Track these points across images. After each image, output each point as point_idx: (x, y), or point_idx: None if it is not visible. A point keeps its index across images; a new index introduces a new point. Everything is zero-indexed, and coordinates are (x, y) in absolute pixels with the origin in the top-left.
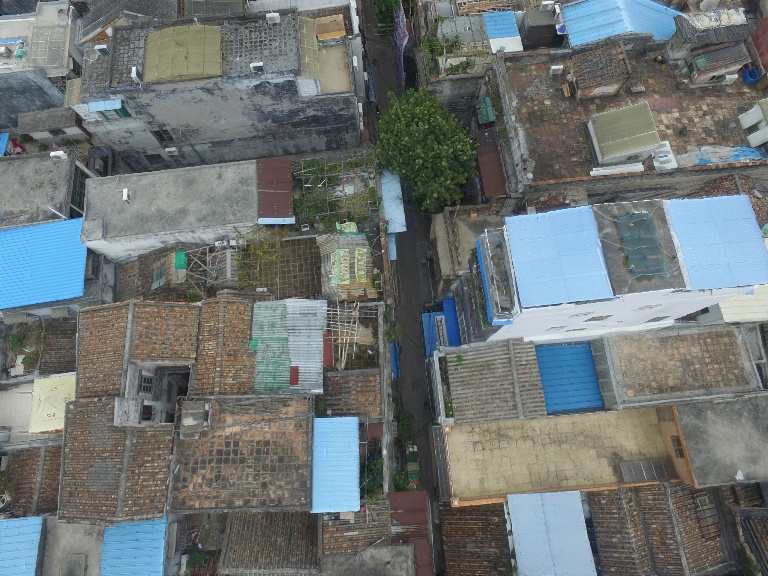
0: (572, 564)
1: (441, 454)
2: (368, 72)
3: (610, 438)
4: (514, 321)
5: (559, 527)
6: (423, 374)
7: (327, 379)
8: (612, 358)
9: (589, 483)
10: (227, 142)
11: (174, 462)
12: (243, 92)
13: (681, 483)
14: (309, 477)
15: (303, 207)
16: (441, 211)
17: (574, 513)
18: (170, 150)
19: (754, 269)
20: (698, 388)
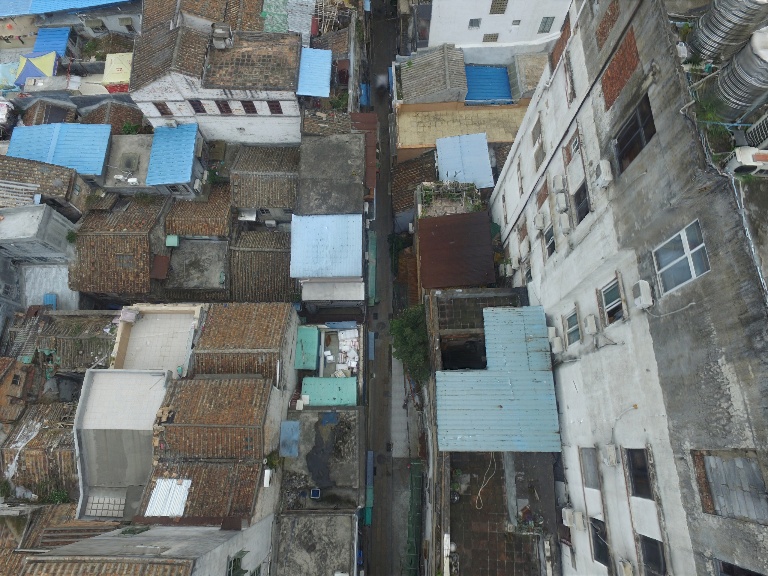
0: (477, 173)
1: (393, 129)
2: None
3: (515, 122)
4: None
5: (470, 154)
6: None
7: (313, 43)
8: (519, 68)
9: None
10: None
11: (207, 63)
12: None
13: None
14: (297, 73)
15: None
16: None
17: (481, 145)
18: None
19: None
20: None
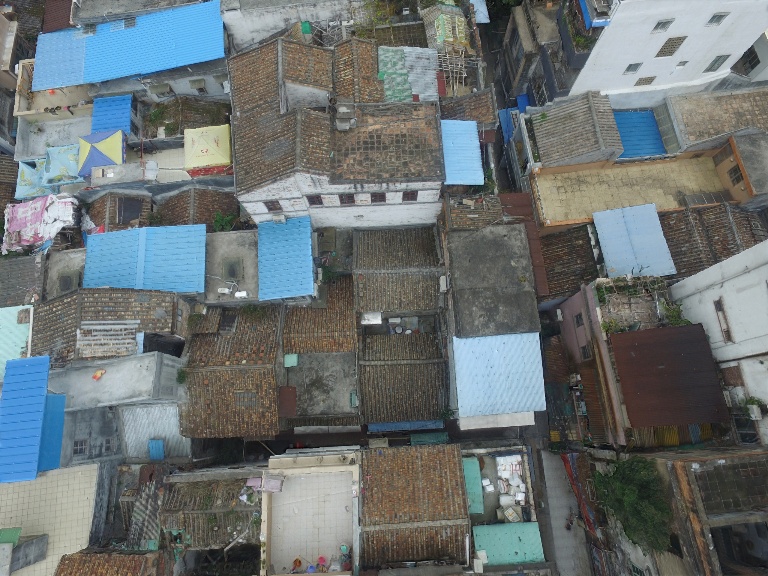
0: (651, 256)
1: None
2: None
3: (674, 181)
4: (607, 31)
5: (639, 231)
6: None
7: (442, 107)
8: (675, 113)
9: None
10: None
11: None
12: None
13: (738, 207)
14: (442, 157)
15: None
16: (520, 4)
17: (651, 220)
18: None
19: None
20: None
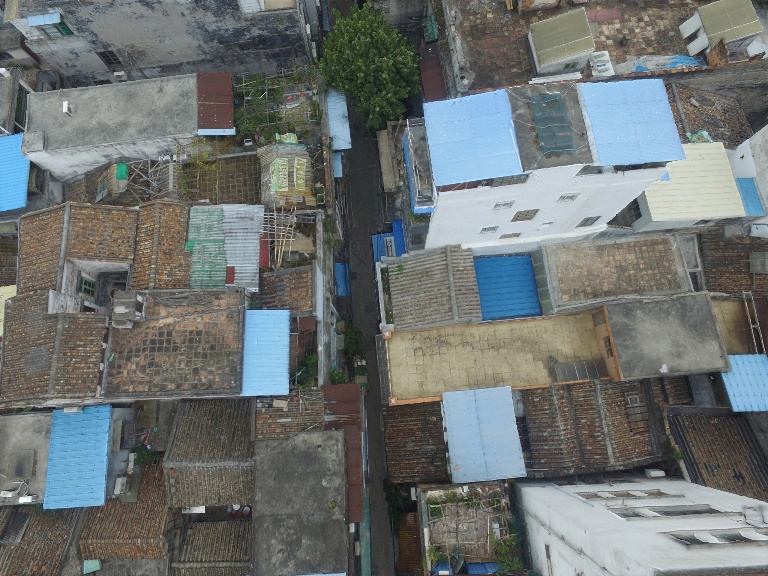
0: (501, 453)
1: (383, 360)
2: (323, 1)
3: (547, 343)
4: (438, 212)
5: (490, 420)
6: None
7: (263, 279)
8: (549, 266)
9: (524, 384)
10: (176, 66)
11: (109, 351)
12: (183, 6)
13: (612, 381)
14: (239, 363)
15: (243, 118)
16: (385, 128)
17: (505, 407)
18: (118, 74)
19: (663, 147)
20: (631, 292)
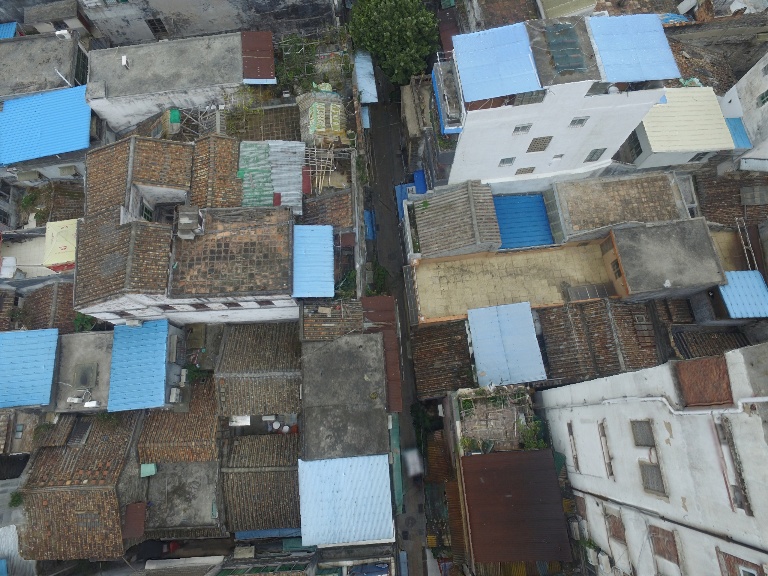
0: (523, 360)
1: (411, 288)
2: None
3: (560, 270)
4: (464, 135)
5: (512, 332)
6: (399, 247)
7: (306, 205)
8: (560, 200)
9: None
10: None
11: (173, 260)
12: None
13: (620, 301)
14: (290, 268)
15: (283, 70)
16: (408, 83)
17: (525, 320)
18: None
19: (660, 68)
20: None
